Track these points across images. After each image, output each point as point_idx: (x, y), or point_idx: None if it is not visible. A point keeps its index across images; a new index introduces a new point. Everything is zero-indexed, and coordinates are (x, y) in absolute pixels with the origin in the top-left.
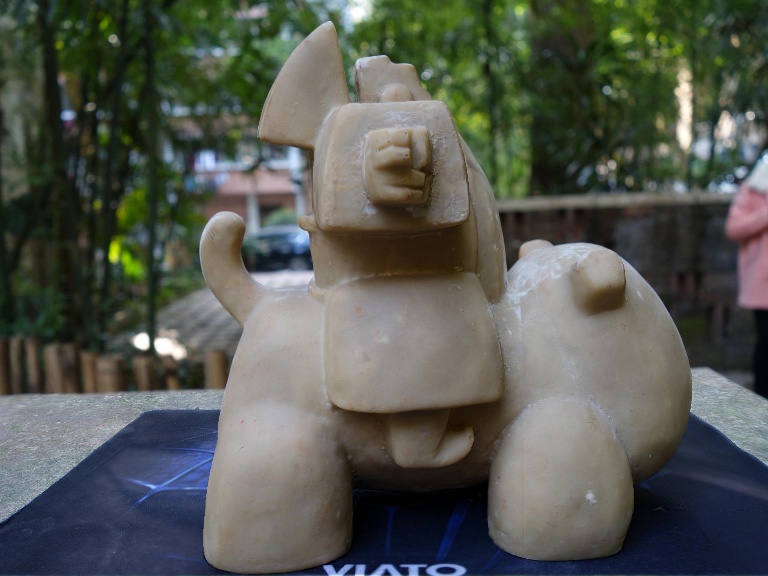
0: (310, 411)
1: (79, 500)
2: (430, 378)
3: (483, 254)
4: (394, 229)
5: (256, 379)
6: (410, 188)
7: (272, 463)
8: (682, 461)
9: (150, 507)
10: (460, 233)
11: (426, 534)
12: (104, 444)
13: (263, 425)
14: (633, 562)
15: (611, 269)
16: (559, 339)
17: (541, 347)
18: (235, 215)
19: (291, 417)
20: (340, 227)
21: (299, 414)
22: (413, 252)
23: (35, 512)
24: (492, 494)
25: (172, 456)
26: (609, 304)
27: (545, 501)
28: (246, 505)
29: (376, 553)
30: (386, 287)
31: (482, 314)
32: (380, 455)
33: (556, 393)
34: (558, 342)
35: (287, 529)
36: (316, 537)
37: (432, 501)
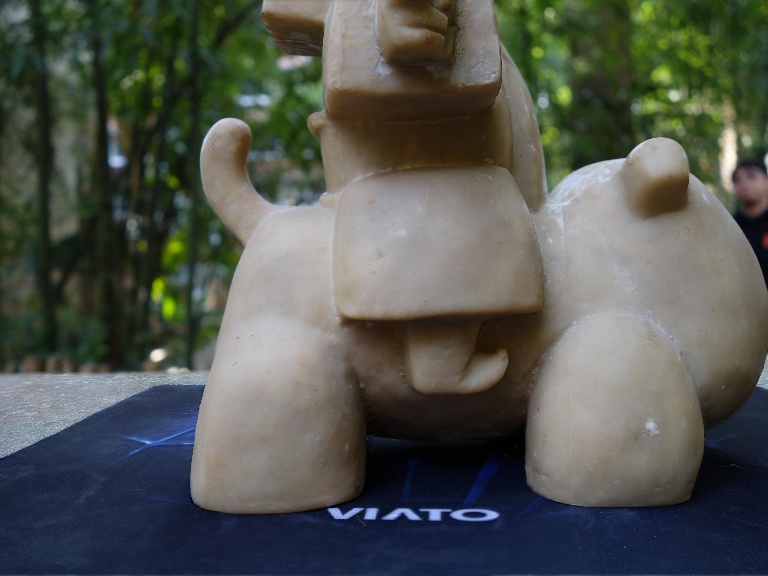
0: (315, 326)
1: (65, 452)
2: (455, 276)
3: (519, 155)
4: (412, 93)
5: (255, 291)
6: (429, 29)
7: (269, 380)
8: (755, 425)
9: (141, 458)
10: (491, 119)
11: (452, 483)
12: (105, 409)
13: (260, 339)
14: (706, 510)
15: (671, 157)
16: (609, 248)
17: (588, 256)
18: (239, 121)
19: (293, 331)
20: (349, 90)
21: (303, 328)
22: (436, 141)
23: (15, 461)
24: (530, 432)
25: (175, 419)
26: (669, 203)
27: (595, 431)
28: (237, 430)
29: (391, 498)
30: (404, 177)
31: (517, 209)
32: (397, 384)
33: (607, 307)
34: (608, 251)
35: (285, 459)
36: (319, 471)
37: (460, 453)
